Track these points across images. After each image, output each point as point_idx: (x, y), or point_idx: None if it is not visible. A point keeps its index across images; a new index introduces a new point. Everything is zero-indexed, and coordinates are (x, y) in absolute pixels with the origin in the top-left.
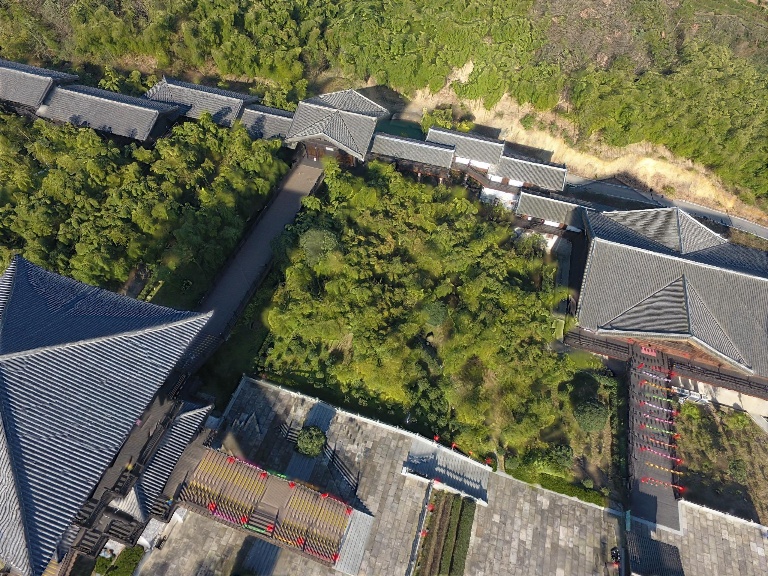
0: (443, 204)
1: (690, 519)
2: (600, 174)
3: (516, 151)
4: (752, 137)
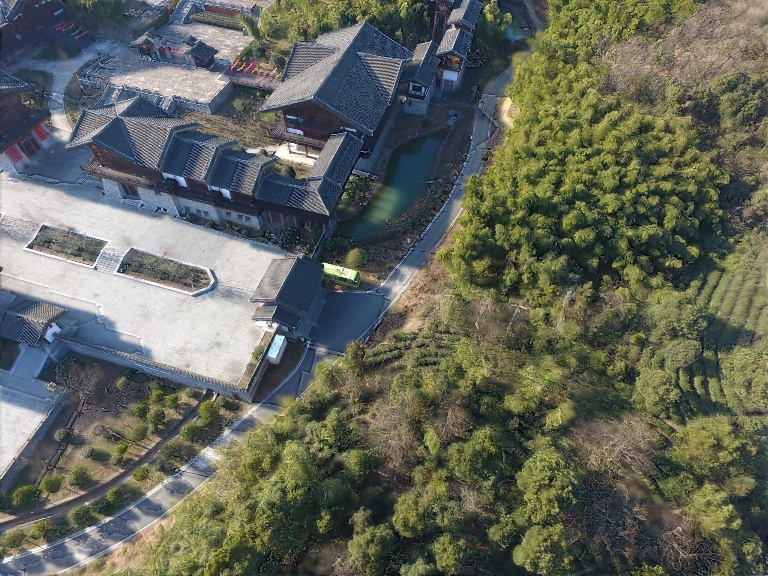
0: (401, 0)
1: (221, 84)
2: (498, 120)
3: (512, 82)
4: (532, 147)
